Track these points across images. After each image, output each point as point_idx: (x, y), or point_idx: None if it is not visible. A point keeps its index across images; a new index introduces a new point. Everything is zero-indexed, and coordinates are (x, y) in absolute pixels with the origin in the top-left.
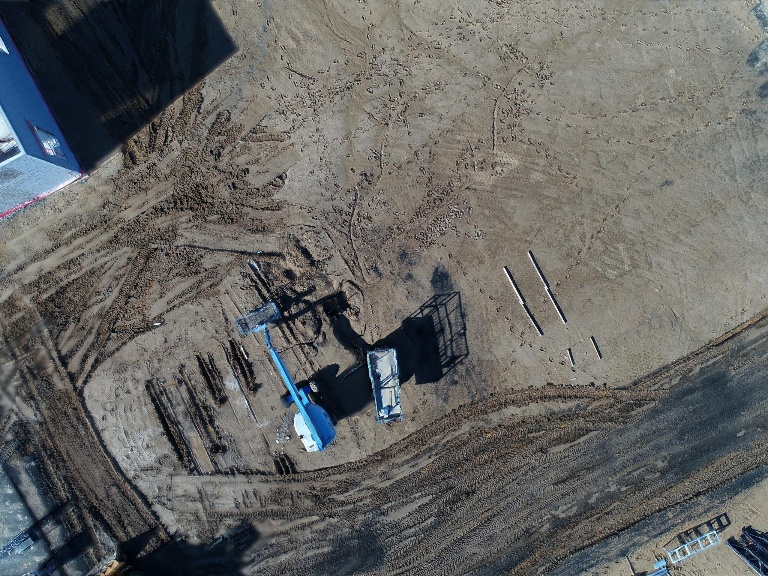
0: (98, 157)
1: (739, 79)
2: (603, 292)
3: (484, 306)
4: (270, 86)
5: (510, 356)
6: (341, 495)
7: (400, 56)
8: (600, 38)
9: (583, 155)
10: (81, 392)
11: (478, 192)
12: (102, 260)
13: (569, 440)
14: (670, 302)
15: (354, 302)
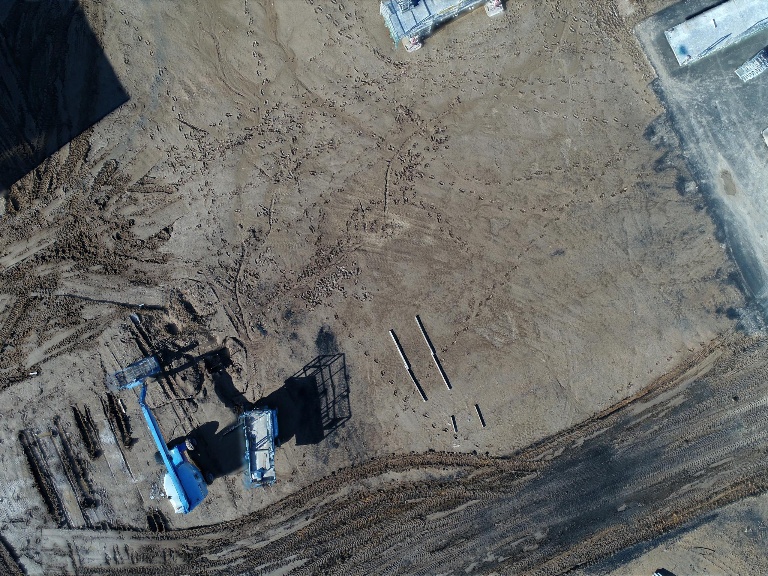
0: None
1: (635, 152)
2: (489, 360)
3: (369, 369)
4: (160, 137)
5: (393, 420)
6: (215, 555)
7: (294, 112)
8: (497, 104)
9: (475, 221)
10: None
11: (367, 253)
12: None
13: (449, 508)
14: (556, 373)
15: (237, 359)
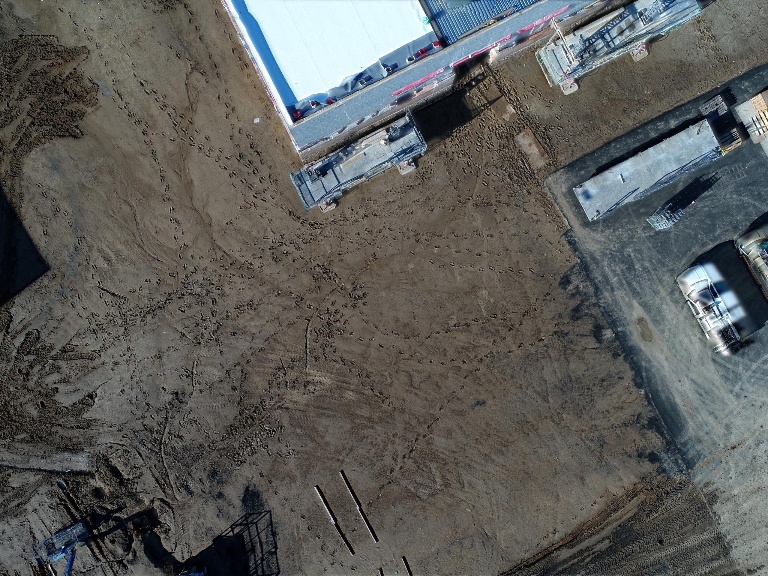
0: None
1: (551, 301)
2: (415, 511)
3: (295, 525)
4: (81, 305)
5: (321, 575)
6: None
7: (212, 275)
8: (413, 259)
9: (396, 375)
10: None
11: (290, 411)
12: None
13: None
14: (482, 522)
15: (165, 520)
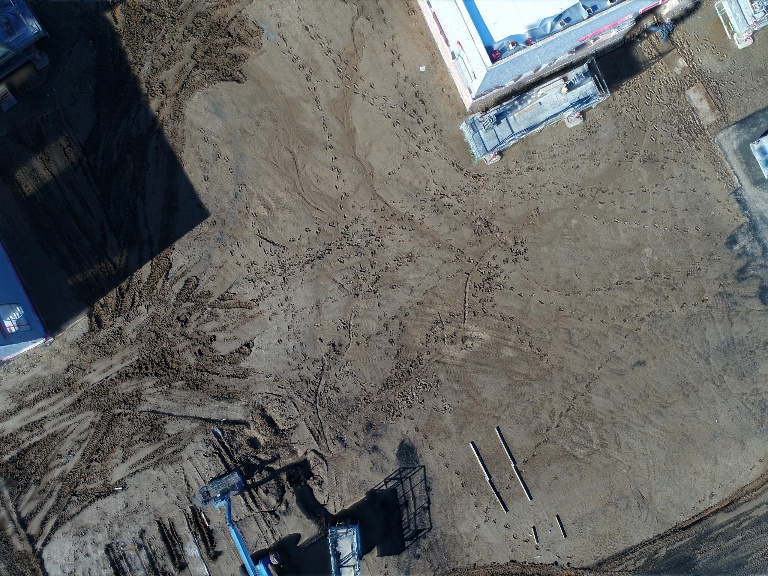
0: (63, 320)
1: (717, 261)
2: (570, 471)
3: (449, 480)
4: (240, 253)
5: (474, 531)
6: None
7: (372, 226)
8: (576, 215)
9: (555, 332)
10: (40, 554)
11: (447, 366)
12: (64, 423)
13: None
14: (638, 483)
15: (318, 472)
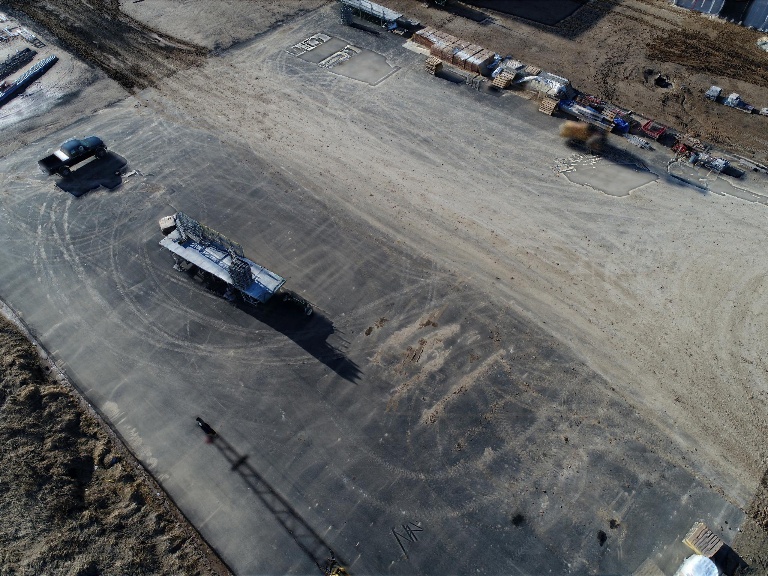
0: None
1: None
2: None
3: None
4: None
5: None
6: None
7: None
8: None
9: None
10: None
11: None
12: None
13: (88, 3)
14: None
15: None
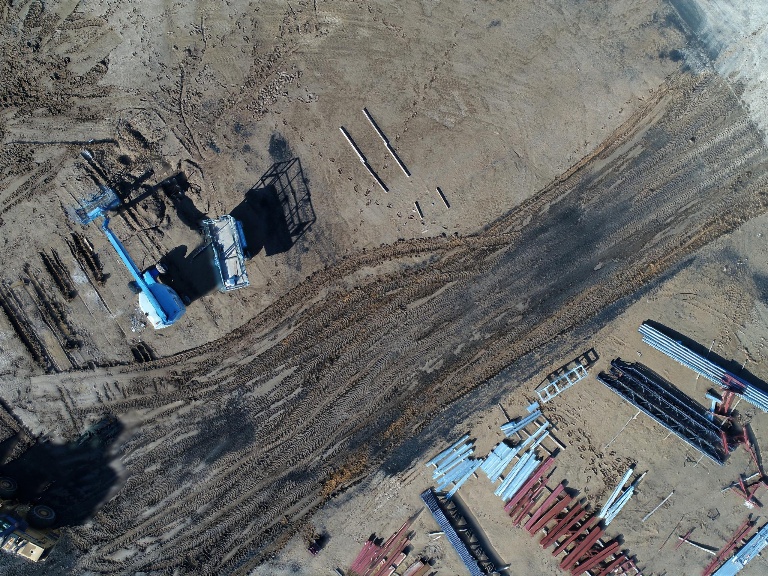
0: None
1: None
2: (443, 141)
3: (325, 169)
4: None
5: (358, 217)
6: (204, 376)
7: None
8: None
9: (406, 5)
10: None
11: (305, 55)
12: None
13: (427, 294)
14: (512, 143)
15: (194, 181)
